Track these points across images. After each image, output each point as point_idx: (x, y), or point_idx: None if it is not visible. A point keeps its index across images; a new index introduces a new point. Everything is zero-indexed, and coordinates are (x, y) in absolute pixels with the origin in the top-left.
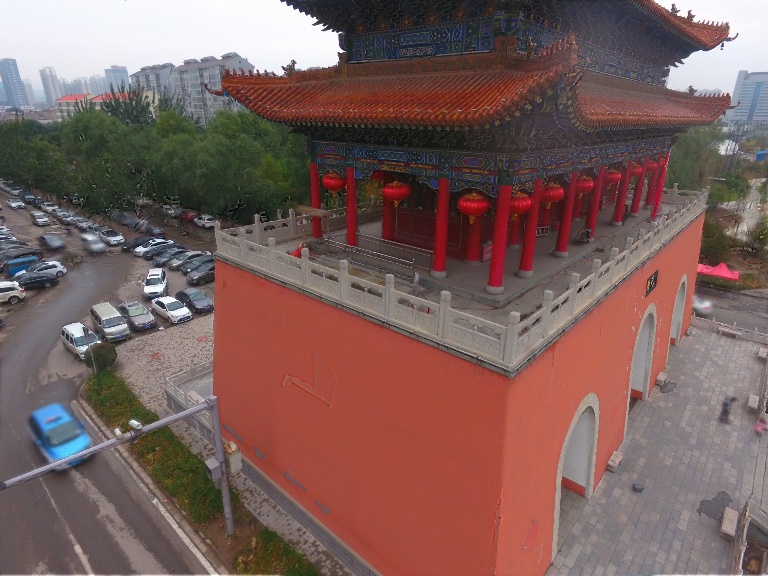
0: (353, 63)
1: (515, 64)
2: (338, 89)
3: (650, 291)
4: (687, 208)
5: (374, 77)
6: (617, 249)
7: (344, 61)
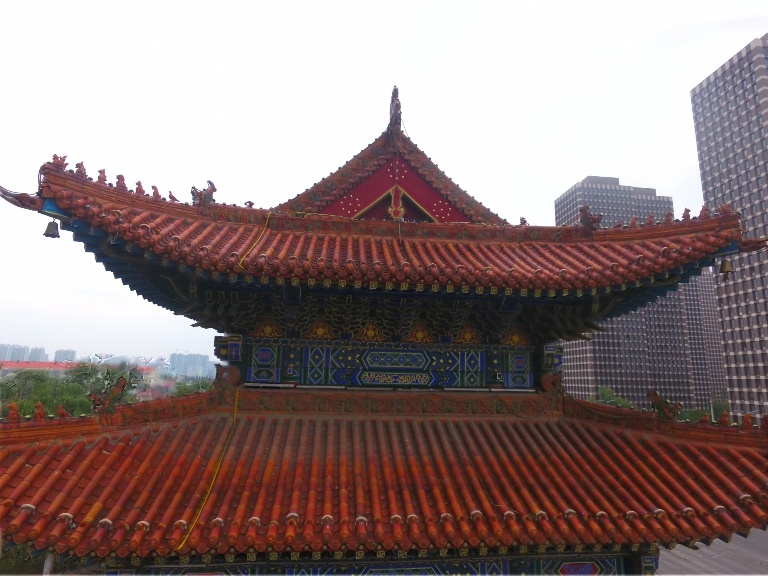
0: (256, 387)
1: (619, 419)
2: (240, 441)
3: None
4: None
5: (313, 415)
6: None
7: (233, 382)
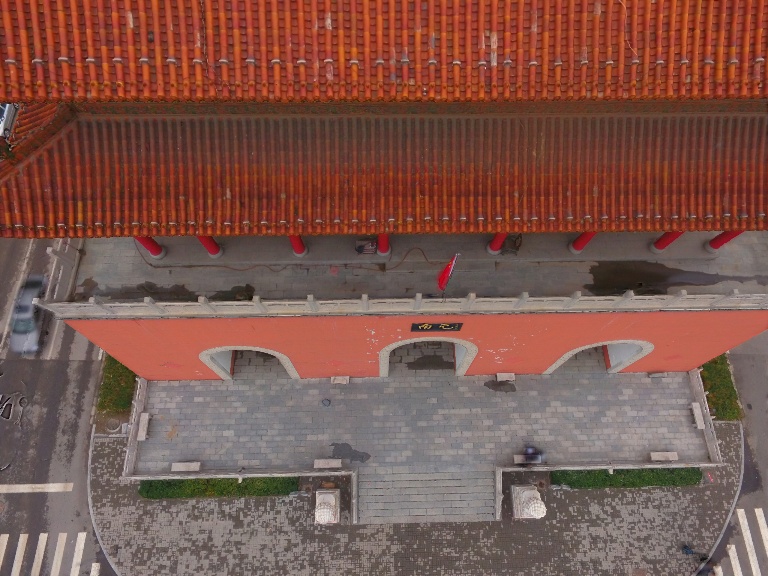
0: None
1: None
2: None
3: (432, 330)
4: (637, 298)
5: None
6: (255, 300)
7: None
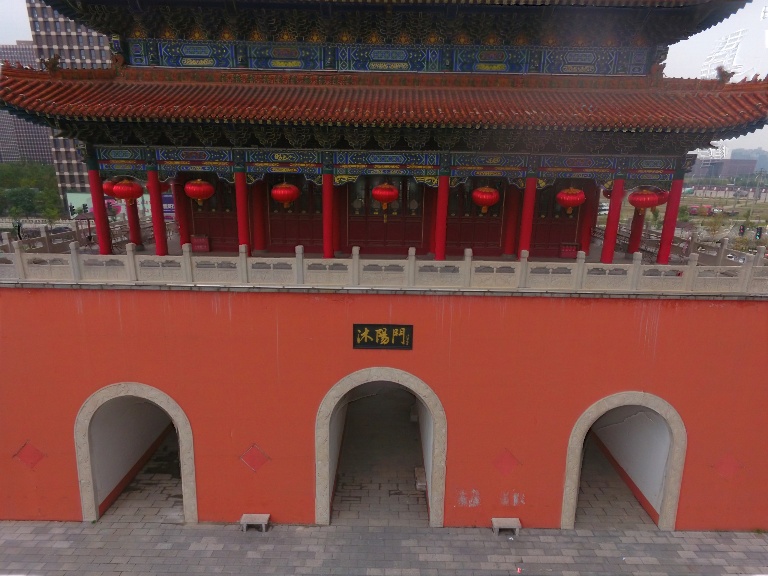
0: None
1: None
2: None
3: None
4: None
5: None
6: None
7: None
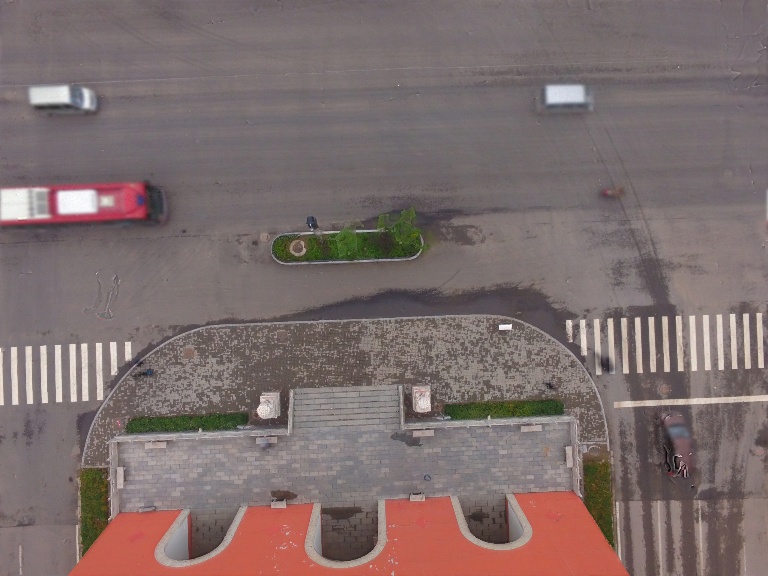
0: None
1: None
2: None
3: None
4: None
5: None
6: None
7: None
